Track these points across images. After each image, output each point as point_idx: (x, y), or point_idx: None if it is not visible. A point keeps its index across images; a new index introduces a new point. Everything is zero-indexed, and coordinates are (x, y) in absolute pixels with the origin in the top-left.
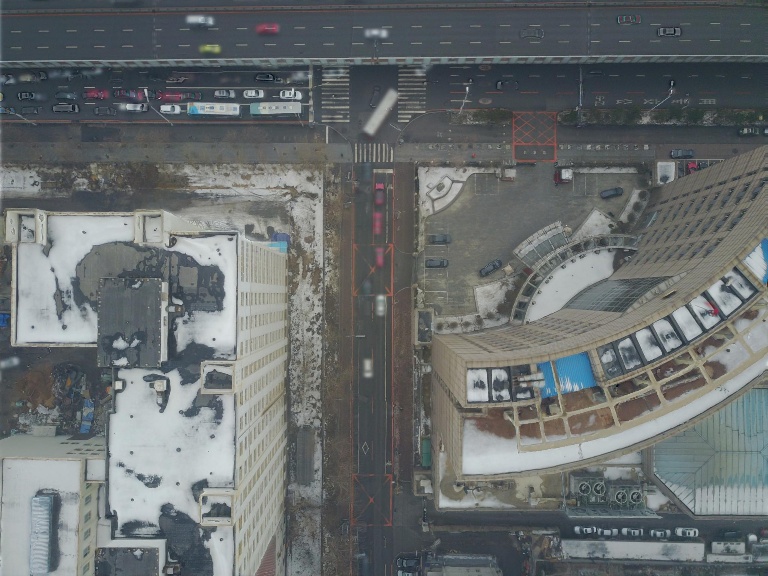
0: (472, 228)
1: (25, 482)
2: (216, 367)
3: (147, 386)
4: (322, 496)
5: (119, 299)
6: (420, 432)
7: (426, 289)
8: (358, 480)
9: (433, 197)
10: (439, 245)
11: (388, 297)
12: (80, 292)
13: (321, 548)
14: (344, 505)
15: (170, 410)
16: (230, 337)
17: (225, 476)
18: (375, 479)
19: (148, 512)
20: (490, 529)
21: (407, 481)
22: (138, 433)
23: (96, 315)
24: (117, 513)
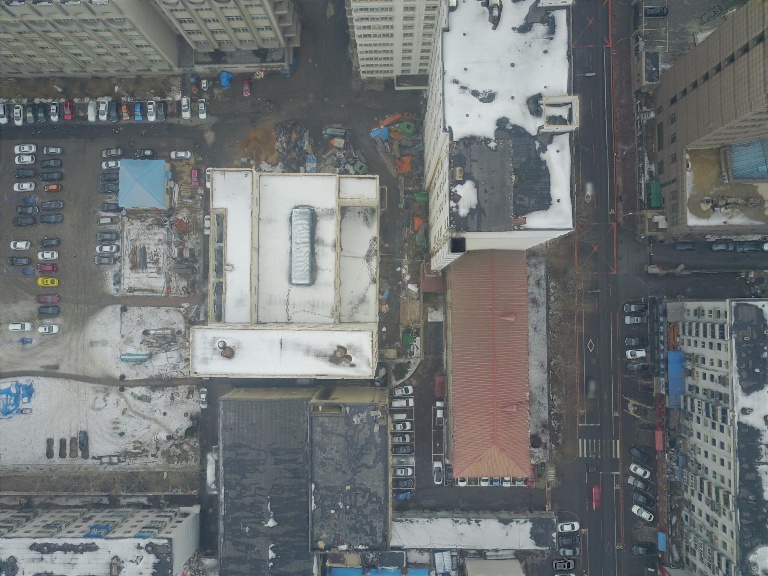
0: None
1: (281, 199)
2: None
3: (478, 5)
4: (546, 244)
5: None
6: (644, 179)
7: (645, 38)
8: (581, 229)
9: None
10: None
11: (607, 48)
12: None
13: (546, 296)
14: (568, 254)
15: (503, 27)
16: None
17: (559, 90)
18: (598, 228)
19: (483, 127)
20: (720, 270)
21: (631, 229)
22: (471, 50)
23: None
24: (452, 129)
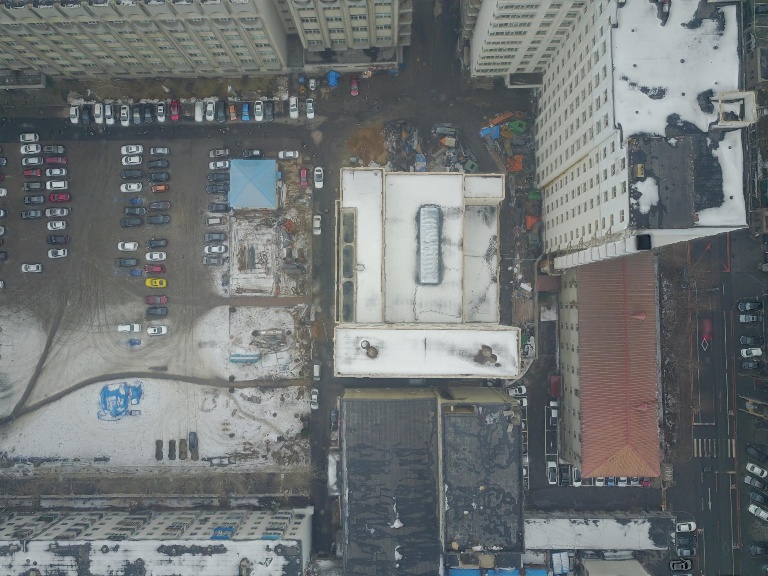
0: None
1: (407, 198)
2: None
3: (646, 1)
4: None
5: None
6: (757, 177)
7: (757, 35)
8: None
9: None
10: None
11: None
12: None
13: (659, 295)
14: (681, 252)
15: (672, 23)
16: None
17: (730, 86)
18: None
19: (653, 124)
20: None
21: None
22: (640, 46)
23: None
24: (622, 126)
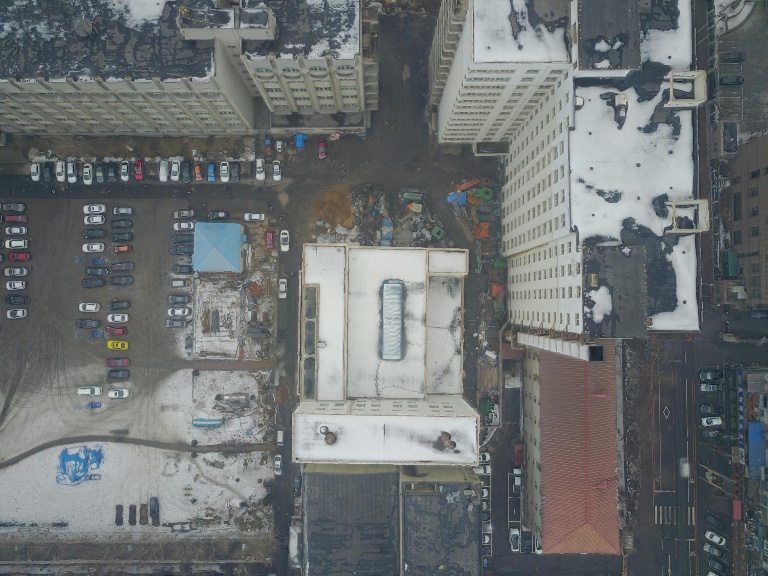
0: (765, 46)
1: (370, 272)
2: (673, 84)
3: (604, 104)
4: None
5: (600, 3)
6: (719, 247)
7: (721, 106)
8: None
9: (728, 15)
10: (733, 63)
11: None
12: (534, 13)
13: (623, 363)
14: None
15: (628, 126)
16: (686, 55)
17: (685, 190)
18: None
19: (609, 227)
20: None
21: (706, 296)
22: (597, 149)
23: (551, 35)
24: (578, 228)
